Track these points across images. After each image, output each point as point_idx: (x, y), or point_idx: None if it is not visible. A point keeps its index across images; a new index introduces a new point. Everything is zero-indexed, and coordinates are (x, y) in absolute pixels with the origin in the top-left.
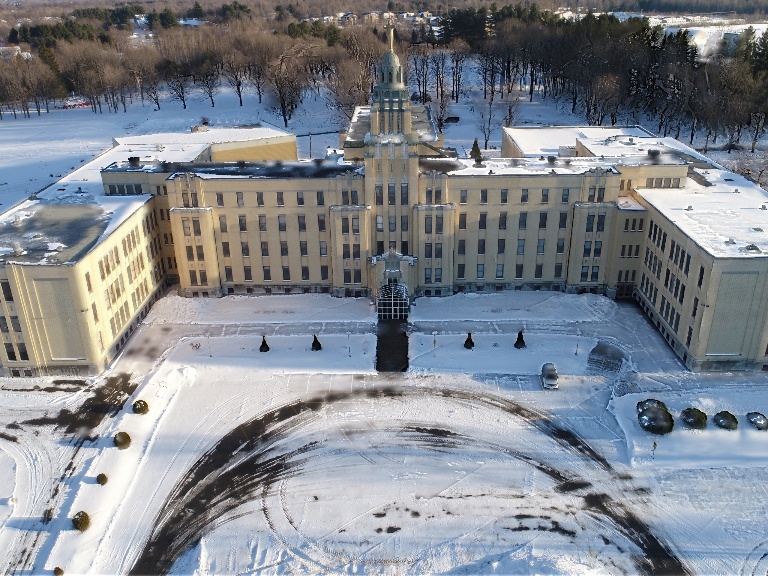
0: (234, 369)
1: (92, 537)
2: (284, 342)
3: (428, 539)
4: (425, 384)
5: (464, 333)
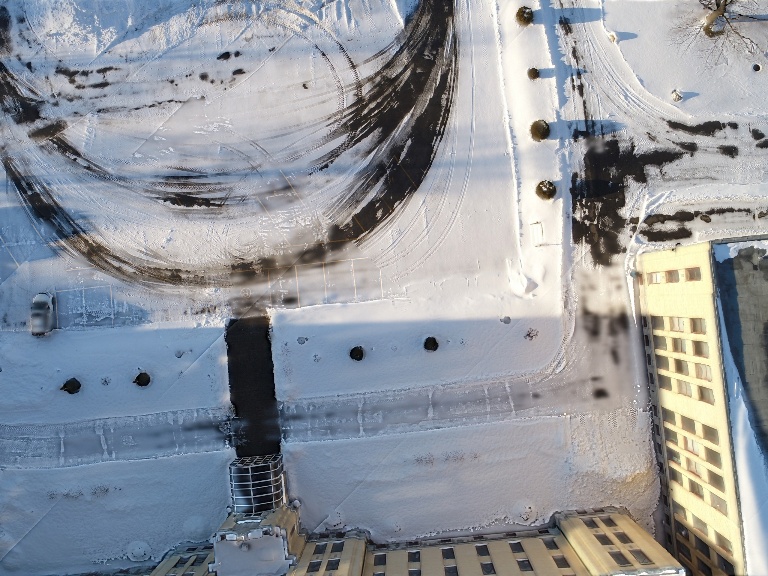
0: (463, 300)
1: (508, 8)
2: (409, 367)
3: (191, 48)
4: (204, 293)
5: (151, 418)
